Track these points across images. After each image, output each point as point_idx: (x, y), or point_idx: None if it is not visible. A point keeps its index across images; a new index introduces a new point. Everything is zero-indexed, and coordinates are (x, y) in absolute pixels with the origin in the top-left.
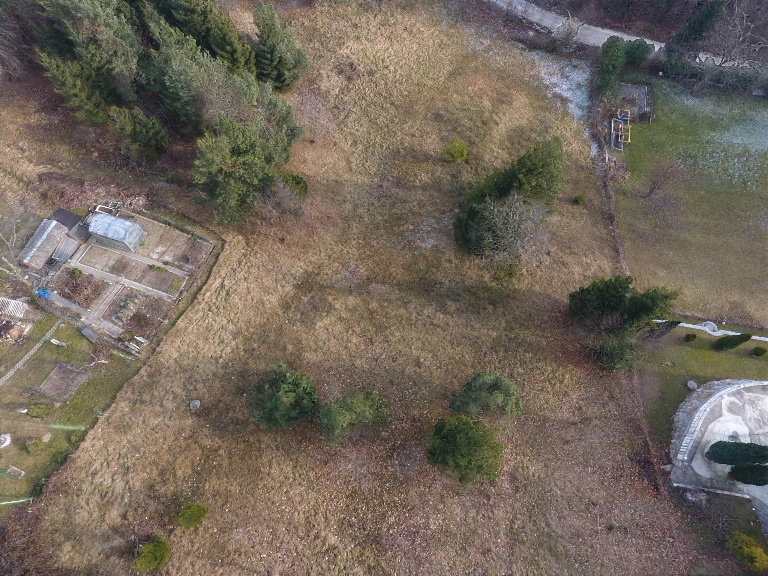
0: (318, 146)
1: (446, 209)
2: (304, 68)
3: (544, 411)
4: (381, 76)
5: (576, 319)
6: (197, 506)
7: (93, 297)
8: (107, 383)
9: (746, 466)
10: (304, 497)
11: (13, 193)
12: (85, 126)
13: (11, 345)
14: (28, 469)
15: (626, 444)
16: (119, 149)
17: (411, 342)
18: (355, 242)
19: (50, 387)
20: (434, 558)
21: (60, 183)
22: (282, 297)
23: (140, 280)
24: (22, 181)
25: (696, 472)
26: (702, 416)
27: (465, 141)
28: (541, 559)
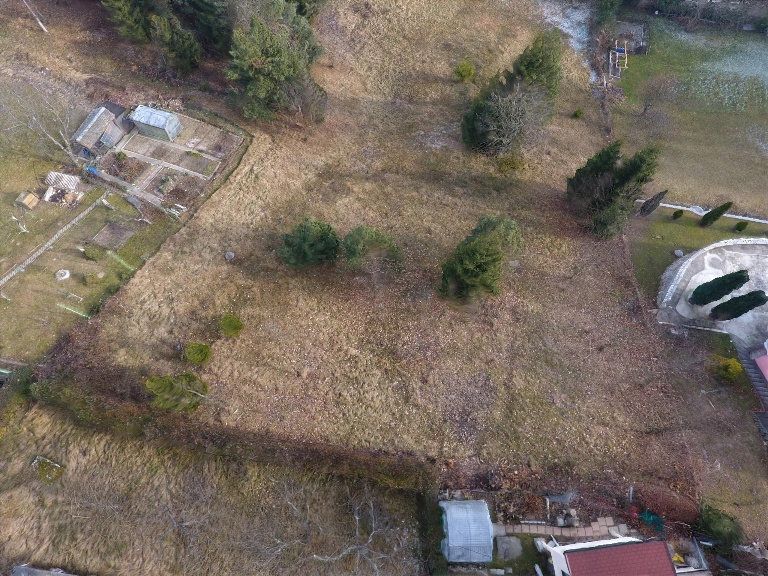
0: (336, 70)
1: (454, 119)
2: (323, 2)
3: (543, 268)
4: (394, 14)
5: (573, 200)
6: (235, 319)
7: (137, 175)
8: (151, 238)
9: (724, 302)
10: (328, 323)
11: (63, 94)
12: (125, 44)
13: (66, 208)
14: (85, 297)
15: (617, 294)
16: (156, 64)
17: (422, 216)
18: (371, 143)
19: (102, 239)
20: (443, 365)
21: (104, 87)
22: (305, 182)
23: (178, 163)
24: (70, 85)
25: (680, 314)
26: (686, 266)
27: (472, 65)
28: (538, 367)
